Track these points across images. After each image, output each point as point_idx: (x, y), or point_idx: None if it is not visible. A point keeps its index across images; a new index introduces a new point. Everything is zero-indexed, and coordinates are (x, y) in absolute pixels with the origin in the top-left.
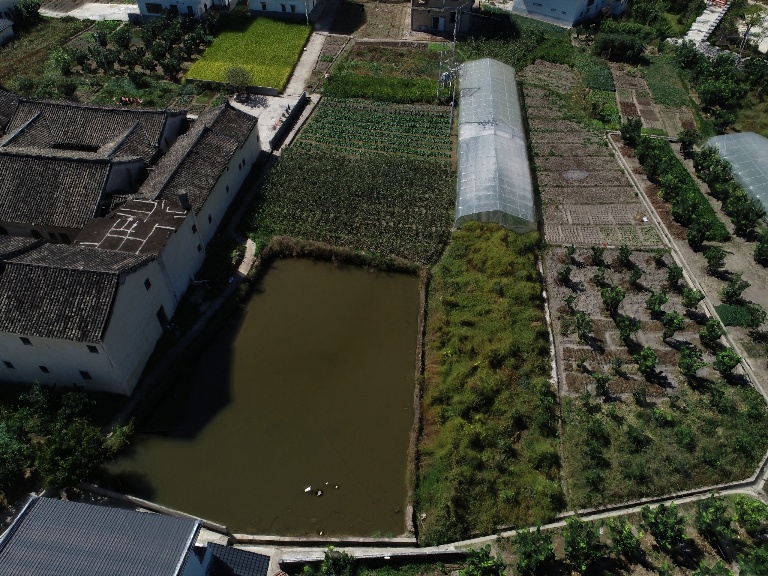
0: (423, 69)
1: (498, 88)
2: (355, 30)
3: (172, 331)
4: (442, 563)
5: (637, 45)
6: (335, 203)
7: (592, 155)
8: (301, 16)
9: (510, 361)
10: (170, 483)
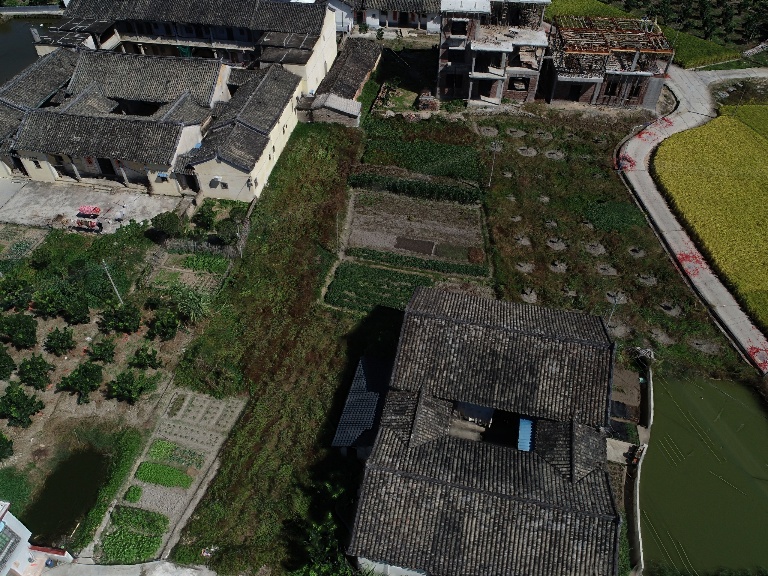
0: None
1: None
2: None
3: None
4: None
5: None
6: None
7: None
8: None
9: None
10: None
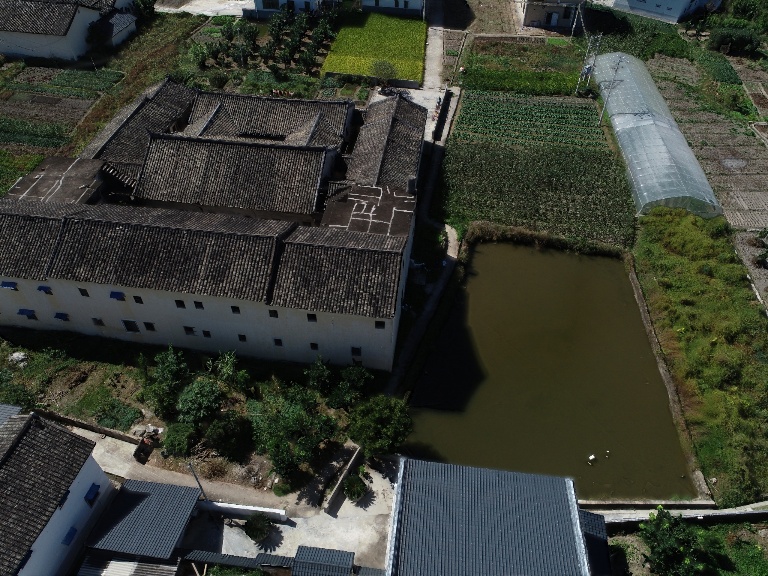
0: (551, 63)
1: (640, 80)
2: (468, 25)
3: (408, 311)
4: (749, 523)
5: (756, 40)
6: (519, 190)
7: (743, 145)
8: (413, 12)
9: (743, 337)
10: (448, 454)
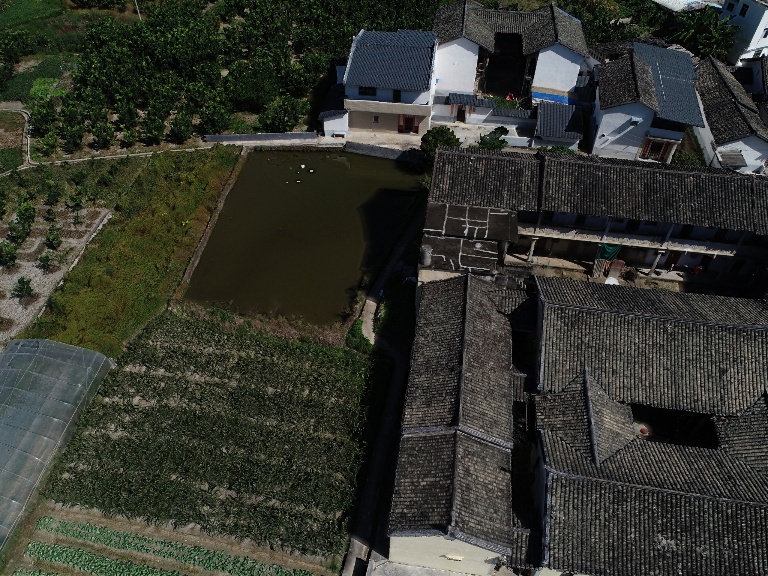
0: None
1: None
2: None
3: None
4: None
5: None
6: None
7: None
8: None
9: (136, 219)
10: None
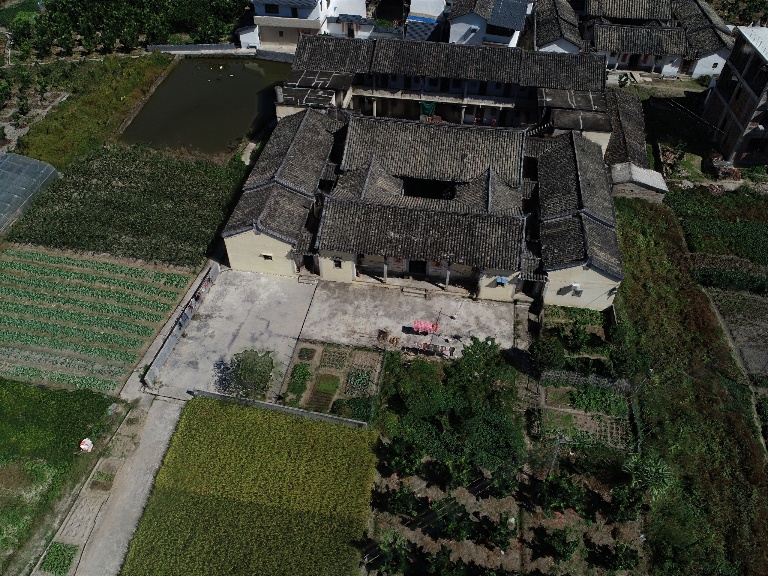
0: None
1: None
2: None
3: None
4: None
5: None
6: None
7: None
8: None
9: None
10: None
